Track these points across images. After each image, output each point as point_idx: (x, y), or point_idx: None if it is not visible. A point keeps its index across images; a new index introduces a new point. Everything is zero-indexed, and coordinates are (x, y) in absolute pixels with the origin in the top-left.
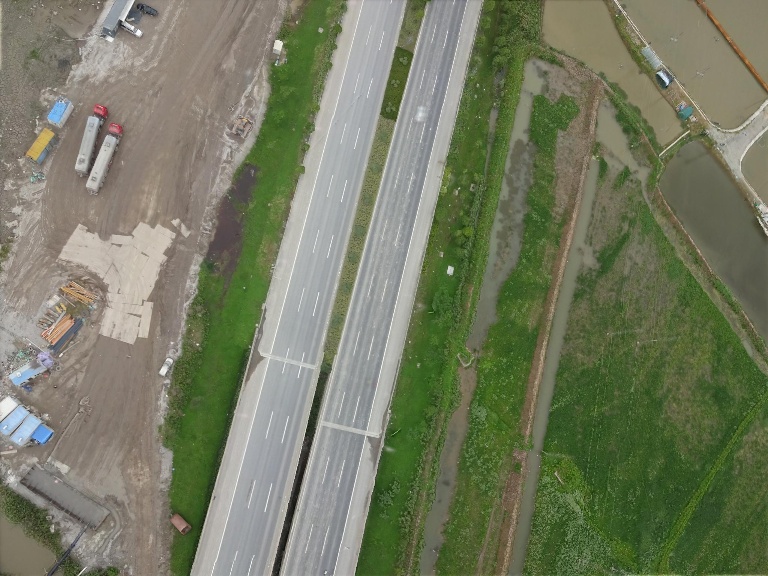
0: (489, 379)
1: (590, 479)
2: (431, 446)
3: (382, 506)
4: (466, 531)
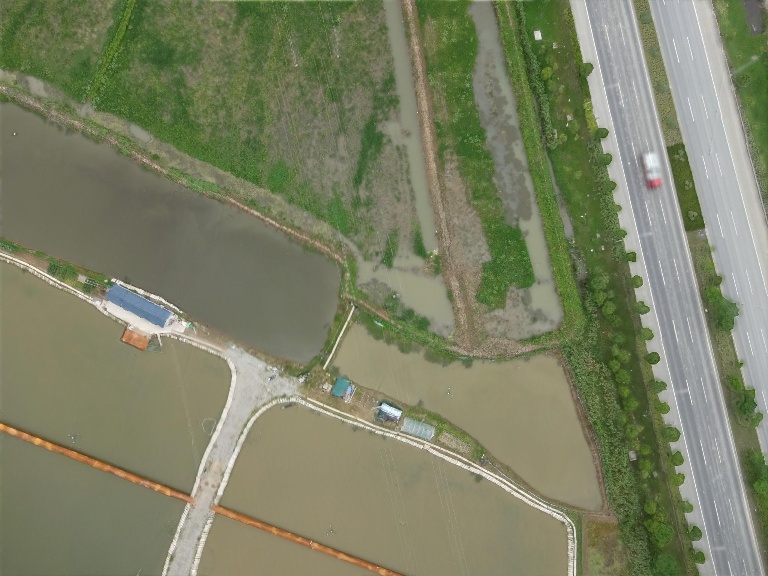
0: None
1: None
2: None
3: None
4: None
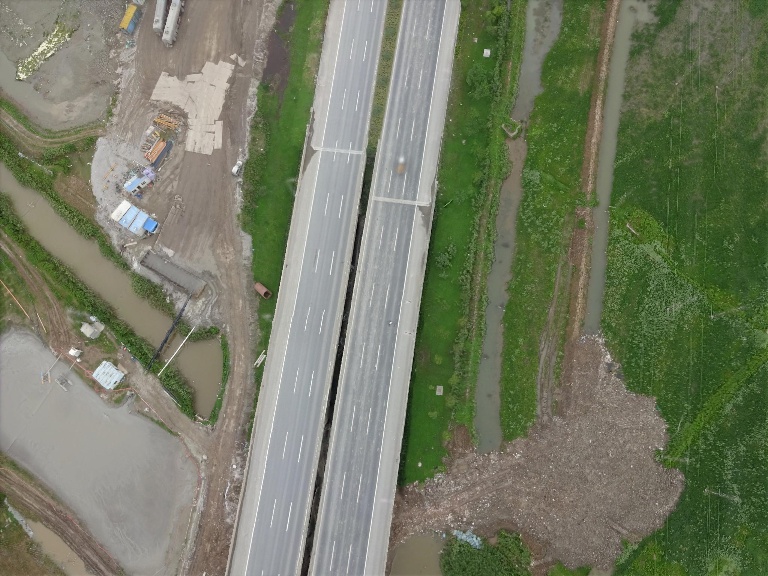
0: (540, 145)
1: (672, 229)
2: (484, 211)
3: (441, 268)
4: (531, 286)
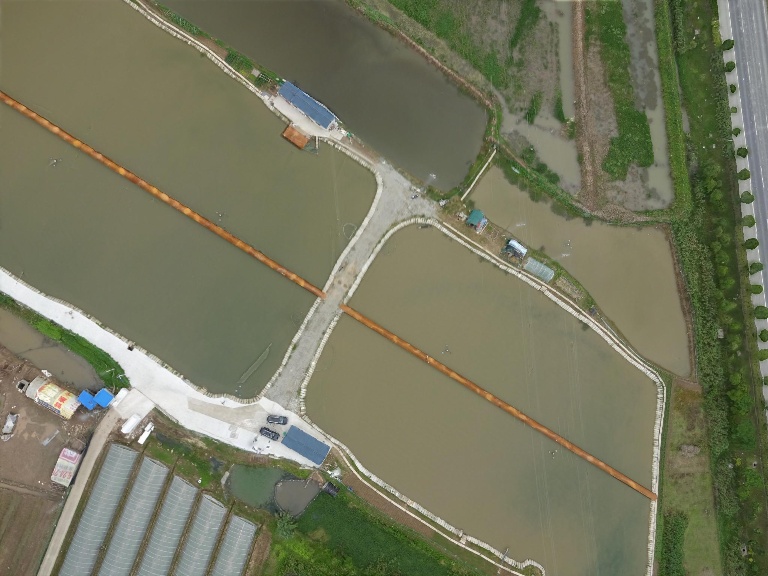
0: None
1: None
2: None
3: None
4: None
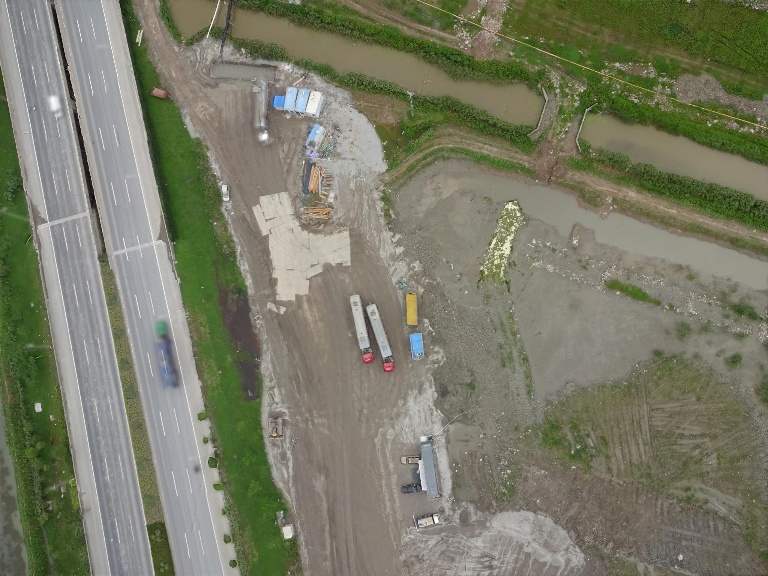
0: None
1: None
2: None
3: None
4: None
